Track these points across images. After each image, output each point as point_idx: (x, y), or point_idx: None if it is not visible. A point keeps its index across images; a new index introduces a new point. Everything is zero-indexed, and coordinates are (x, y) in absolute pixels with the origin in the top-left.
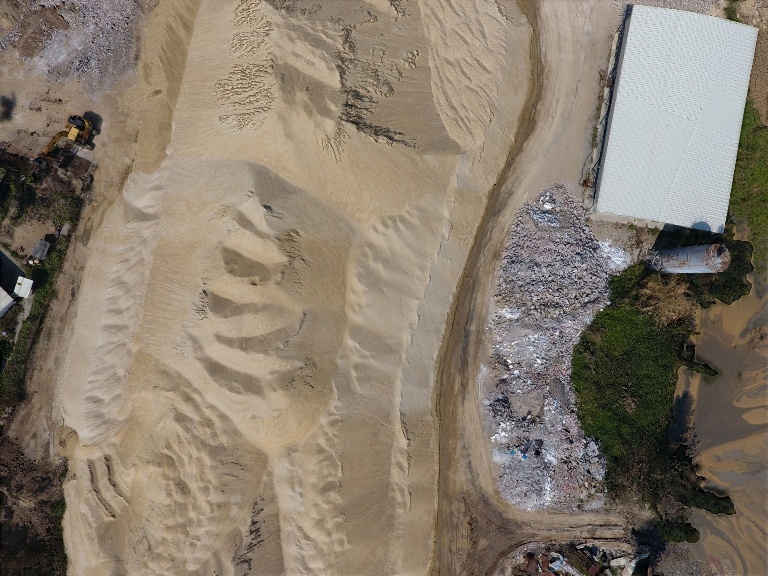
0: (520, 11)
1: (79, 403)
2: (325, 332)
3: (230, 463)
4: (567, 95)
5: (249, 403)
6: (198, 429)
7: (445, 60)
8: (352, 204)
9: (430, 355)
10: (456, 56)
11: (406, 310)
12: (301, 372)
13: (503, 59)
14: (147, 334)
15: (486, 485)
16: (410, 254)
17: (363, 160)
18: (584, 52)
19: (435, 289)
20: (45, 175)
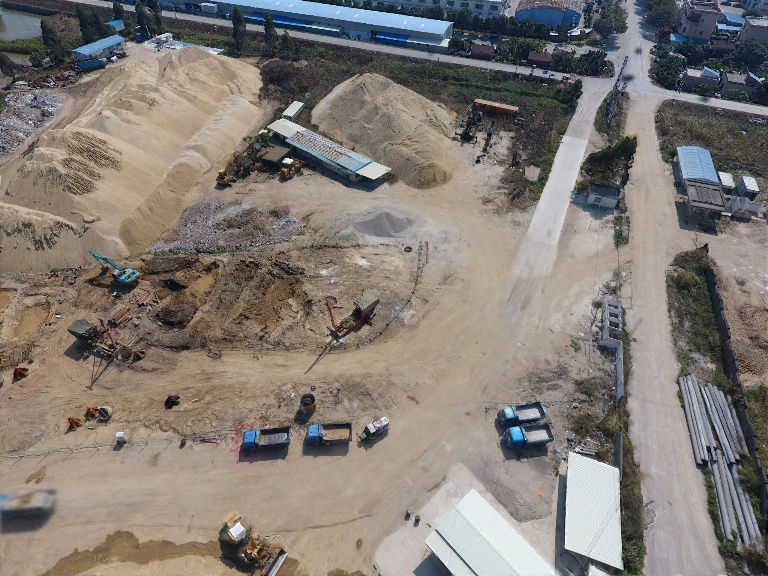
0: None
1: None
2: None
3: None
4: None
5: None
6: None
7: None
8: None
9: None
10: None
11: None
12: None
13: None
14: (202, 117)
15: None
16: None
17: None
18: None
19: None
20: None
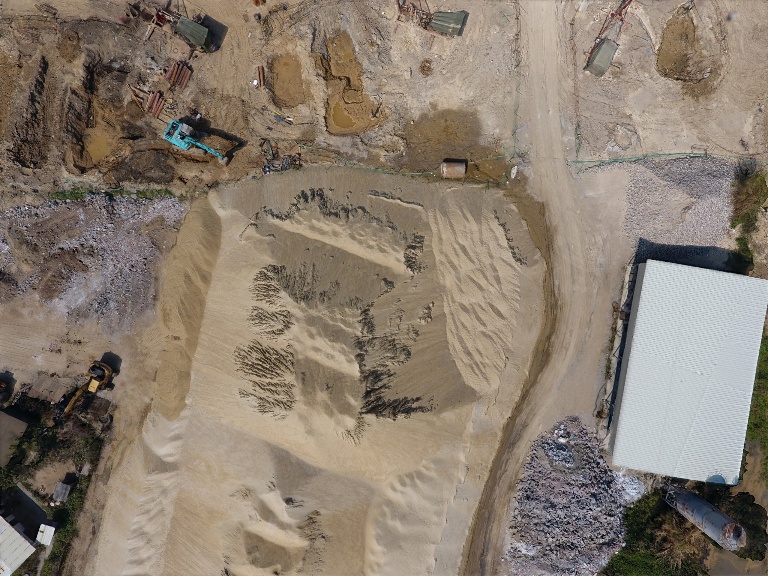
0: (533, 245)
1: None
2: None
3: None
4: (580, 327)
5: None
6: None
7: (460, 306)
8: (370, 471)
9: None
10: (471, 301)
11: (423, 555)
12: None
13: (517, 305)
14: None
15: None
16: (427, 504)
17: (382, 438)
18: (597, 284)
19: (451, 529)
20: (66, 420)
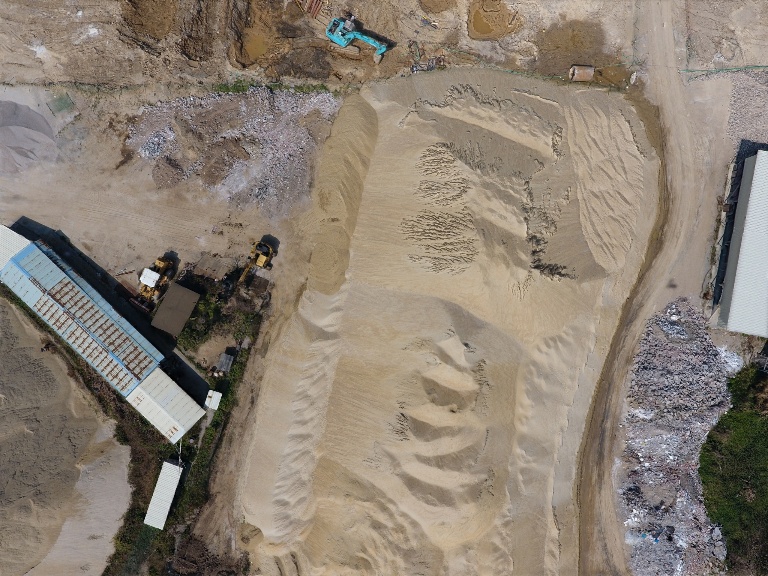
0: (650, 144)
1: (266, 505)
2: (501, 444)
3: (419, 563)
4: (689, 218)
5: (442, 513)
6: (393, 535)
7: (591, 193)
8: (523, 330)
9: (573, 451)
10: (600, 189)
11: (558, 416)
12: (486, 483)
13: (641, 192)
14: (331, 443)
15: (619, 564)
16: (564, 368)
17: (540, 296)
18: (704, 180)
19: (580, 395)
20: (230, 295)
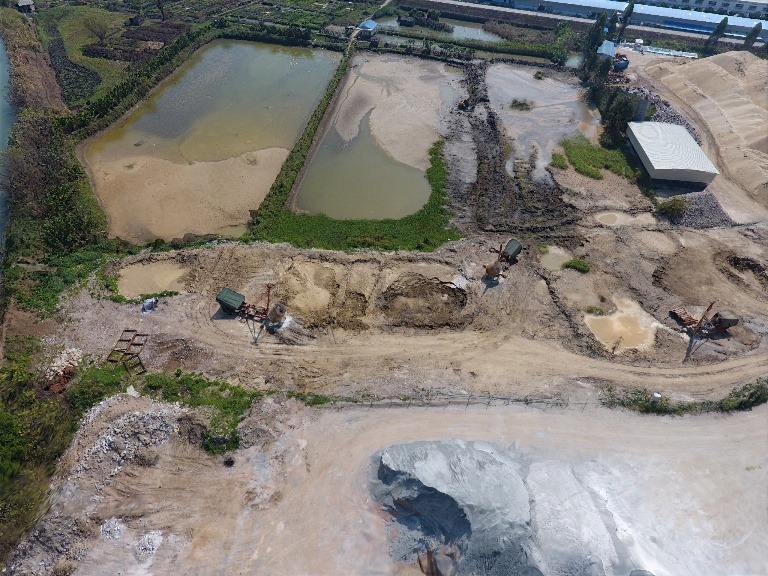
0: (760, 196)
1: None
2: None
3: (763, 78)
4: None
5: None
6: None
7: None
8: None
9: None
10: None
11: None
12: None
13: None
14: None
15: (655, 93)
16: None
17: None
18: None
19: None
20: None
